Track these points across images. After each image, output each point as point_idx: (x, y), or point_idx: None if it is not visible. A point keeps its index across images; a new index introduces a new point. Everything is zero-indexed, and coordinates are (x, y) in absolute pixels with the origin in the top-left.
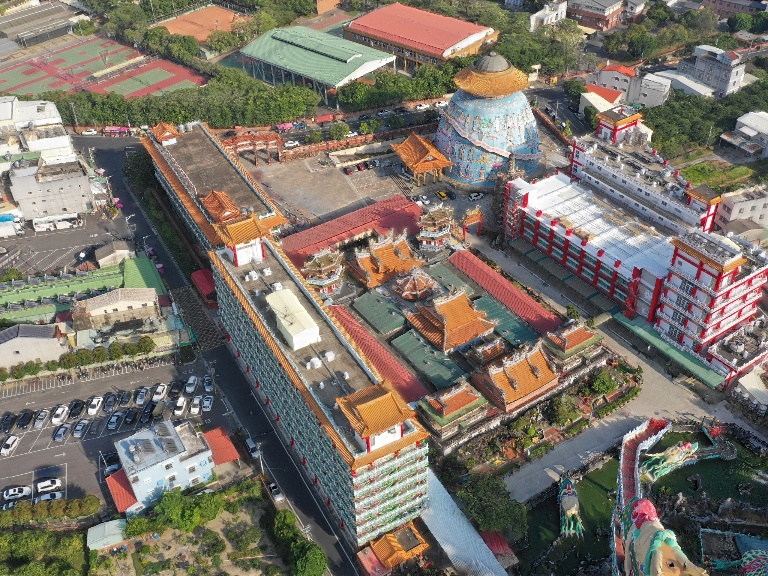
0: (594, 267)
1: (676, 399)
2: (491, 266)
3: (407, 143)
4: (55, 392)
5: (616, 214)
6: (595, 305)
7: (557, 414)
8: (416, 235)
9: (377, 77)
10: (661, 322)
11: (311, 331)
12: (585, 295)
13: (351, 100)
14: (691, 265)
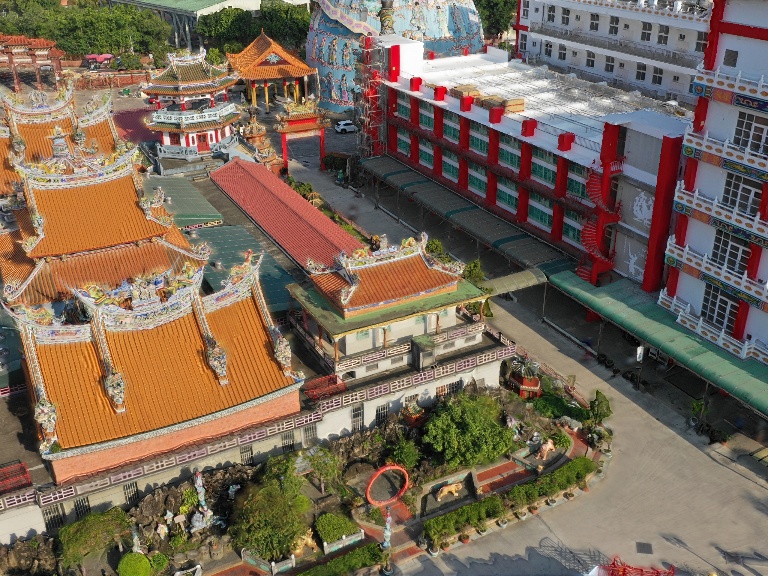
0: (517, 173)
1: (719, 507)
2: (298, 190)
3: (250, 48)
4: None
5: (588, 85)
6: (509, 257)
7: (244, 508)
8: None
9: (262, 4)
10: (679, 284)
11: None
12: (489, 238)
13: (214, 31)
14: (766, 44)
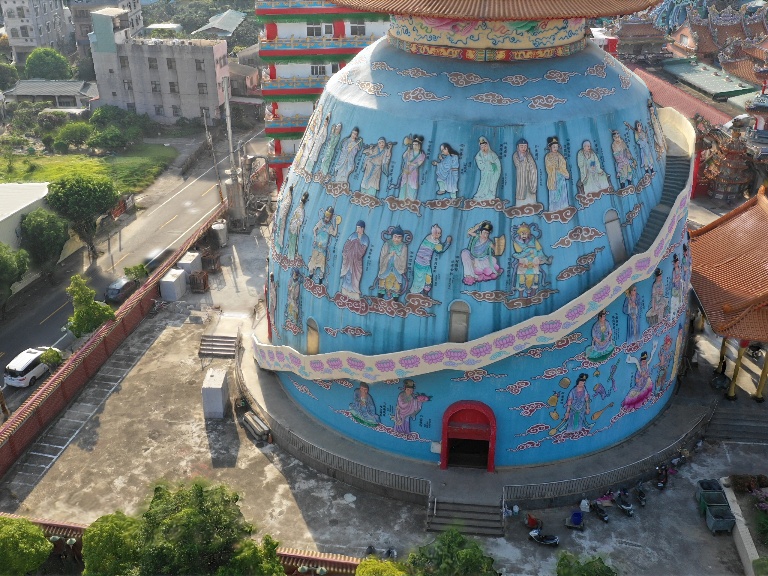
0: None
1: None
2: None
3: None
4: None
5: None
6: None
7: None
8: None
9: None
10: None
11: None
12: None
13: None
14: None
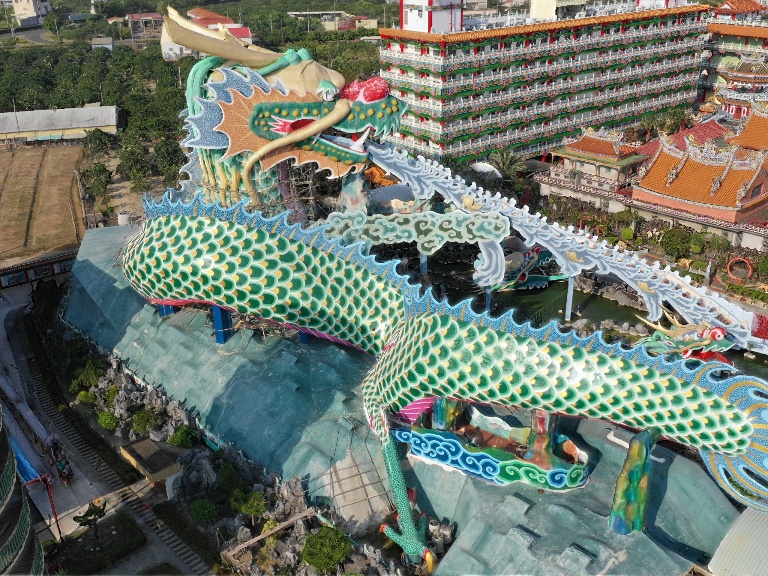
0: None
1: None
2: None
3: None
4: None
5: None
6: None
7: None
8: None
9: None
10: None
11: (549, 3)
12: None
13: None
14: None
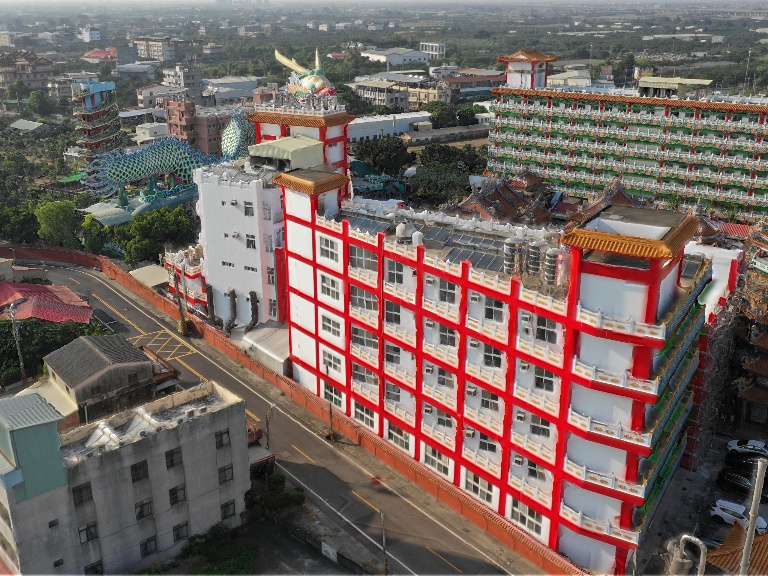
0: None
1: None
2: None
3: None
4: None
5: None
6: None
7: None
8: None
9: None
10: None
11: None
12: None
13: None
14: None
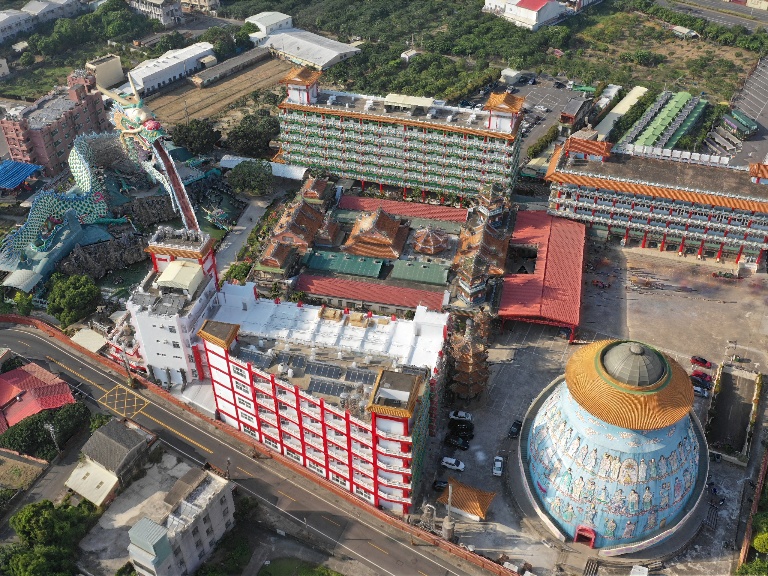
0: None
1: None
2: None
3: None
4: (544, 134)
5: None
6: None
7: None
8: (500, 296)
9: None
10: None
11: None
12: None
13: None
14: None
